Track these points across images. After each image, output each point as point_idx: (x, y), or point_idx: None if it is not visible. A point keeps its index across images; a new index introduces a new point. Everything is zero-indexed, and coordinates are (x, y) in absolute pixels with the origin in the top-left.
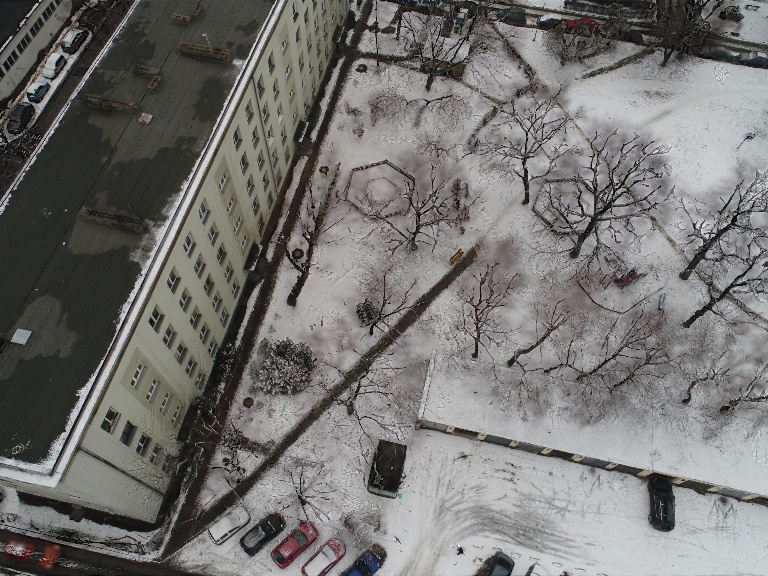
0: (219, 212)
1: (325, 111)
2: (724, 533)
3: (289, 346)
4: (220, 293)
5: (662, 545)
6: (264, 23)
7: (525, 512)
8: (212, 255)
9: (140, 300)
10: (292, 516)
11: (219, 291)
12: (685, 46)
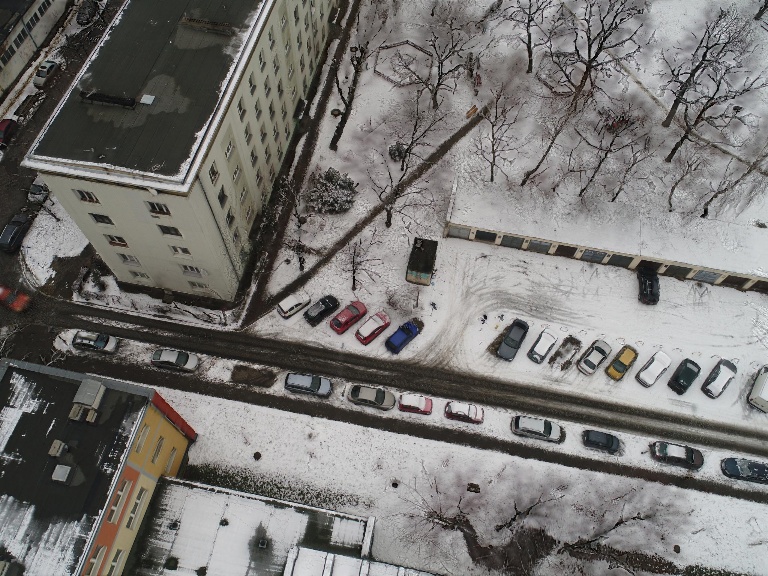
0: (280, 47)
1: (352, 4)
2: (700, 307)
3: (335, 174)
4: (278, 126)
5: (649, 316)
6: None
7: (536, 294)
8: (274, 84)
9: (235, 79)
10: (345, 299)
11: (277, 123)
12: None
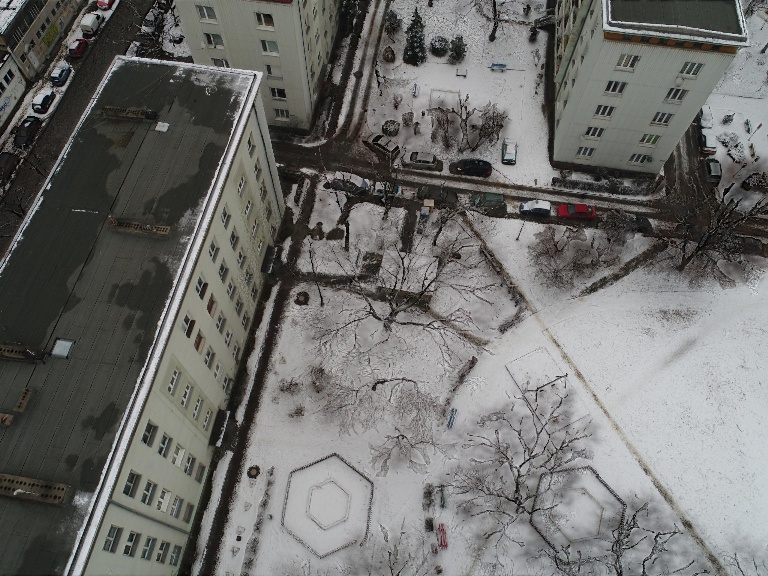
0: None
1: (255, 372)
2: None
3: None
4: None
5: None
6: (127, 408)
7: None
8: None
9: None
10: None
11: None
12: (710, 260)
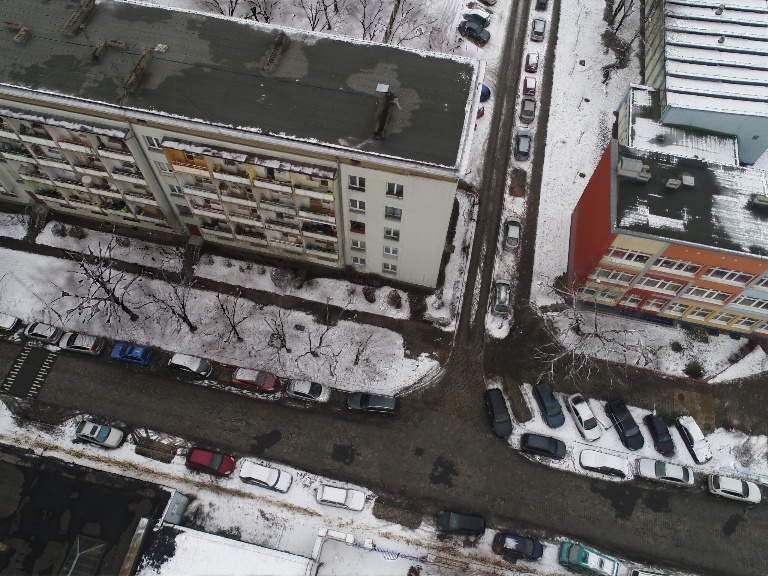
0: None
1: None
2: None
3: None
4: None
5: None
6: None
7: (434, 18)
8: None
9: None
10: None
11: None
12: None
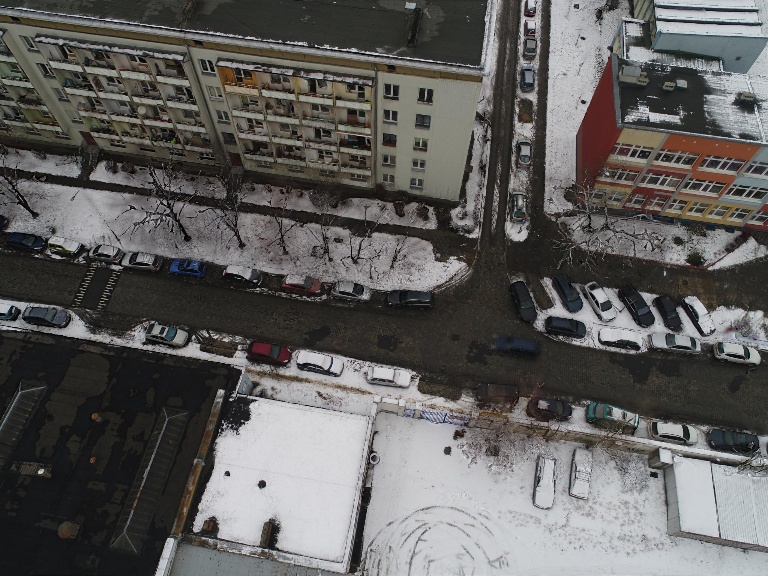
0: None
1: None
2: None
3: None
4: None
5: None
6: None
7: None
8: None
9: None
10: None
11: None
12: None
